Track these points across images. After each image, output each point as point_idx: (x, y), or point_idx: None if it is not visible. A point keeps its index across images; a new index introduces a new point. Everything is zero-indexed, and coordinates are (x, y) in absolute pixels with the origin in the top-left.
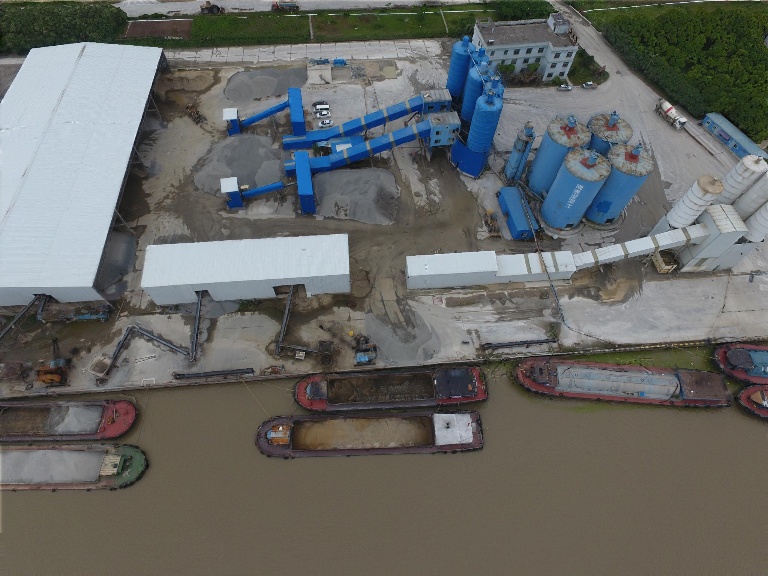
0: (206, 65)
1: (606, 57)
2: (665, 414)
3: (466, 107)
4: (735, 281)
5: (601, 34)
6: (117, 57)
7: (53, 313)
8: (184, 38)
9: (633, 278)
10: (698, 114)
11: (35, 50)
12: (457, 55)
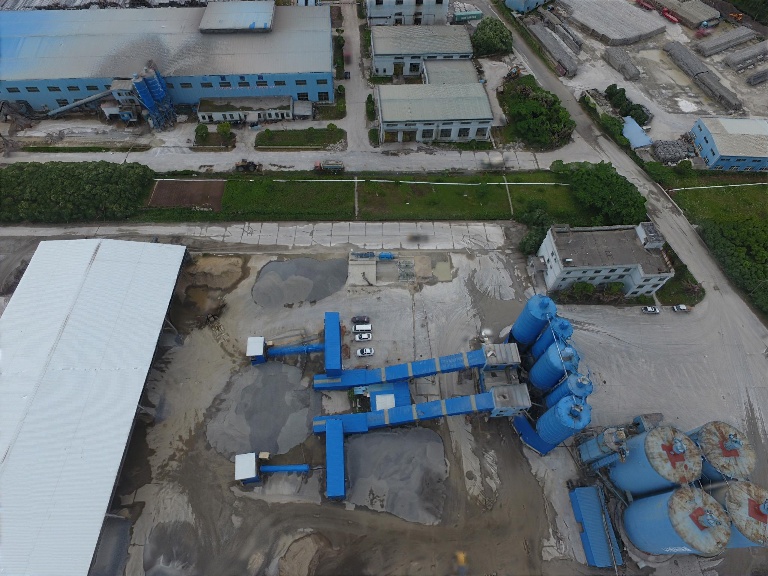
0: (235, 248)
1: (701, 263)
2: None
3: (538, 377)
4: None
5: (695, 229)
6: (133, 262)
7: None
8: (214, 208)
9: None
10: None
11: (45, 244)
12: (532, 317)
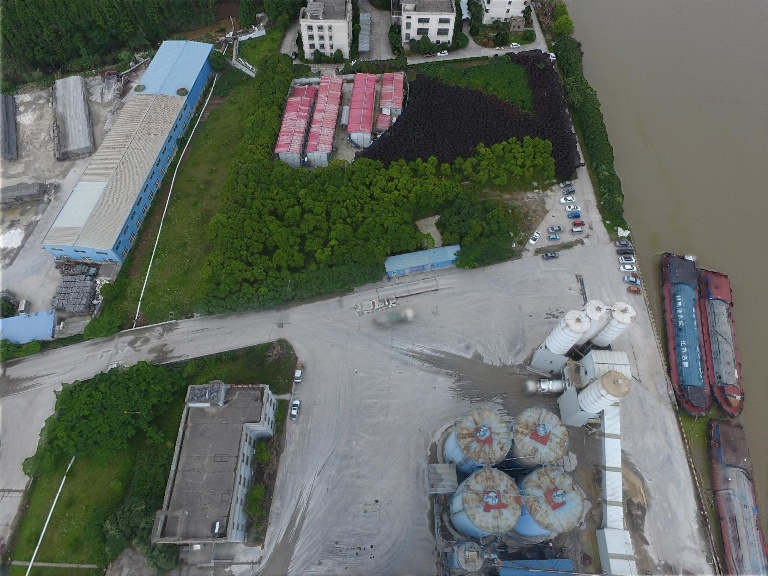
0: None
1: (247, 328)
2: (762, 492)
3: None
4: None
5: (202, 316)
6: None
7: None
8: None
9: None
10: (381, 277)
11: None
12: None
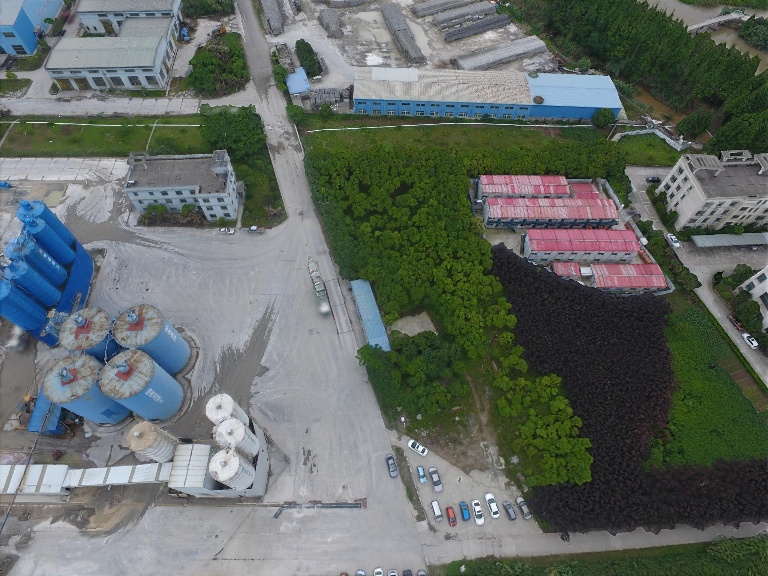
0: None
1: (298, 193)
2: None
3: None
4: (257, 515)
5: None
6: None
7: None
8: None
9: (142, 500)
10: (346, 279)
11: None
12: None
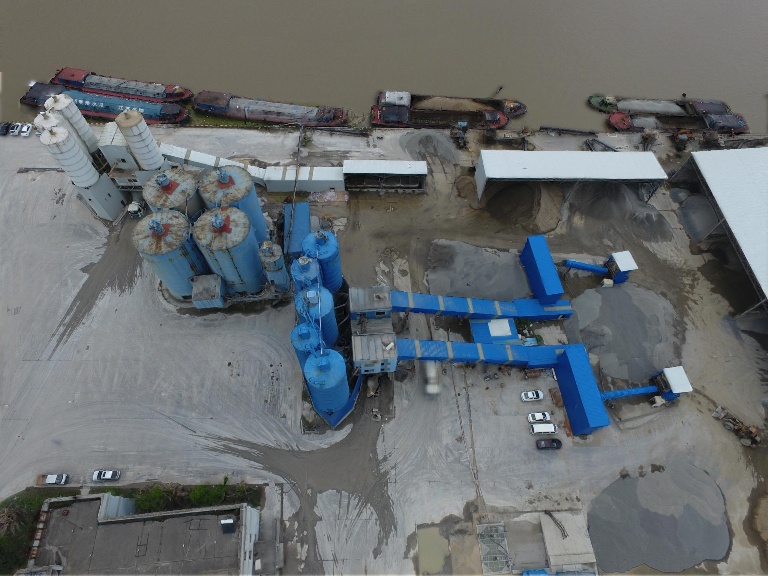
0: None
1: None
2: (249, 95)
3: None
4: None
5: None
6: None
7: None
8: None
9: None
10: None
11: None
12: None
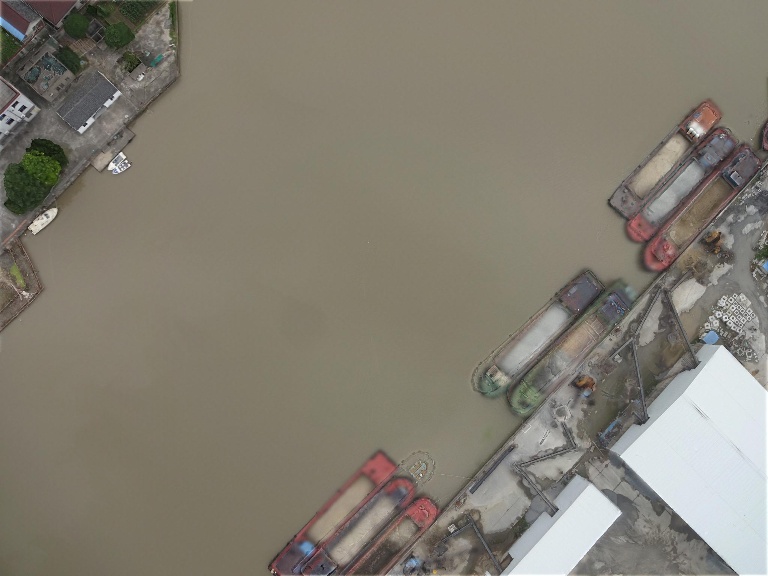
0: None
1: None
2: None
3: None
4: None
5: None
6: None
7: (632, 411)
8: None
9: None
10: None
11: None
12: None
